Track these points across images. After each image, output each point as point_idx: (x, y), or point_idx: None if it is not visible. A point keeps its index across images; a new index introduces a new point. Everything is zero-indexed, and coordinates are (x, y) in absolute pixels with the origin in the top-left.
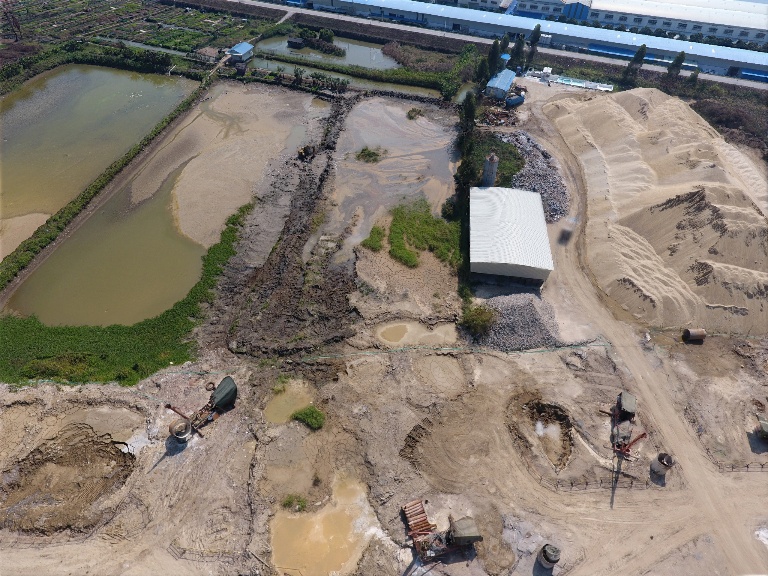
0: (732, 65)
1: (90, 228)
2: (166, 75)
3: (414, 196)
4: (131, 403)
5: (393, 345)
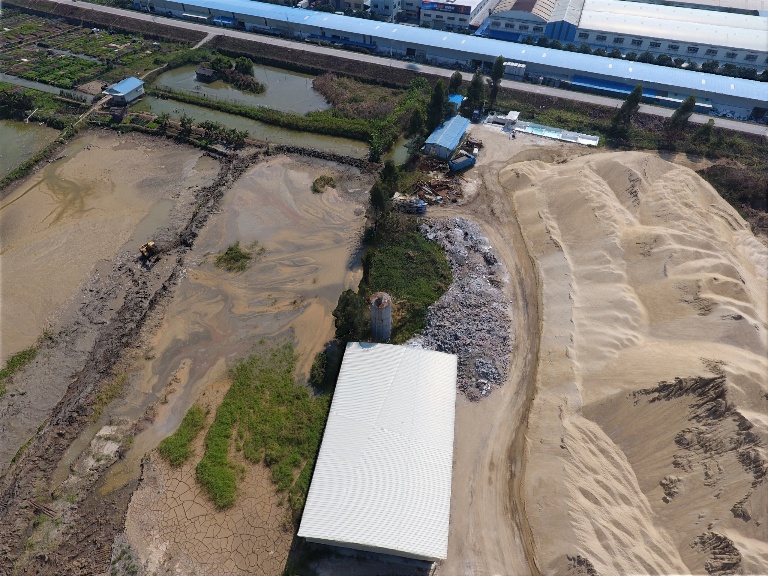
0: (757, 105)
1: None
2: (24, 122)
3: (277, 338)
4: None
5: None
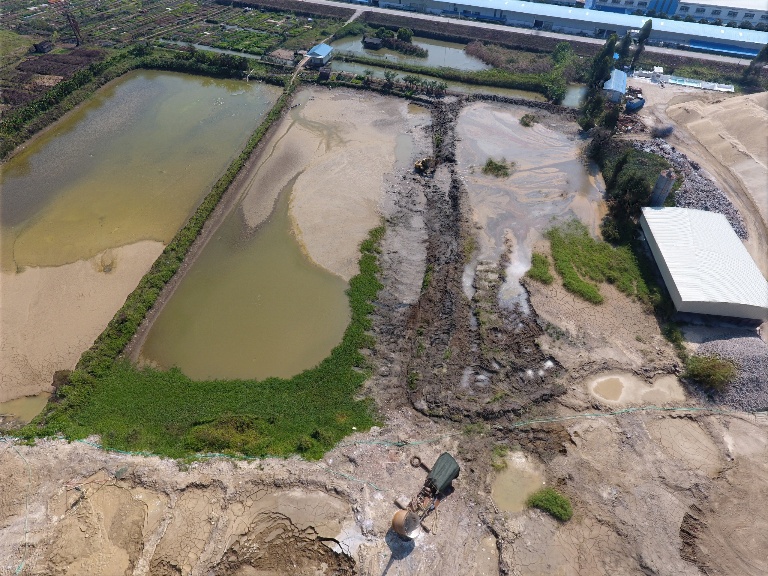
0: None
1: (210, 258)
2: (244, 80)
3: (564, 216)
4: (328, 485)
5: (614, 405)
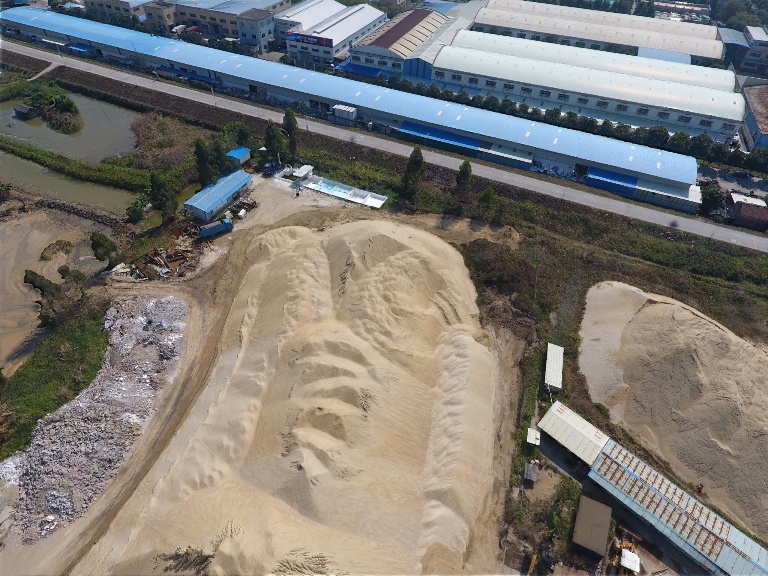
0: (578, 162)
1: None
2: None
3: None
4: None
5: None
